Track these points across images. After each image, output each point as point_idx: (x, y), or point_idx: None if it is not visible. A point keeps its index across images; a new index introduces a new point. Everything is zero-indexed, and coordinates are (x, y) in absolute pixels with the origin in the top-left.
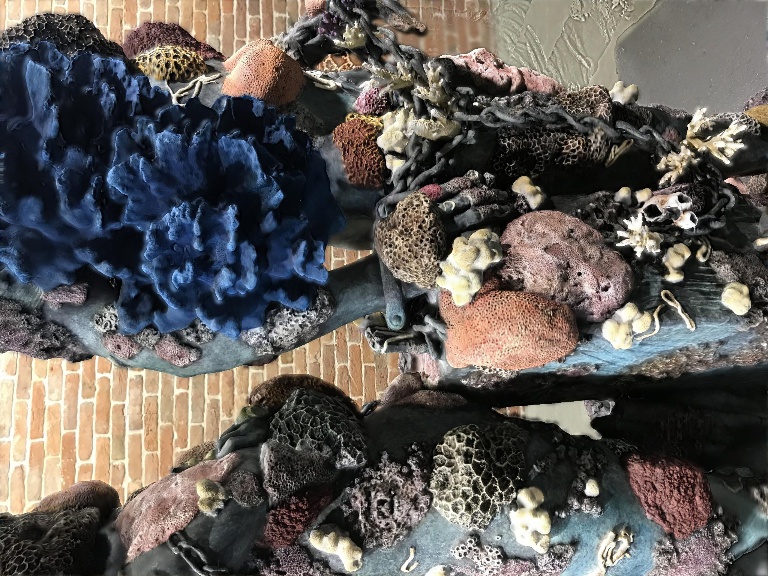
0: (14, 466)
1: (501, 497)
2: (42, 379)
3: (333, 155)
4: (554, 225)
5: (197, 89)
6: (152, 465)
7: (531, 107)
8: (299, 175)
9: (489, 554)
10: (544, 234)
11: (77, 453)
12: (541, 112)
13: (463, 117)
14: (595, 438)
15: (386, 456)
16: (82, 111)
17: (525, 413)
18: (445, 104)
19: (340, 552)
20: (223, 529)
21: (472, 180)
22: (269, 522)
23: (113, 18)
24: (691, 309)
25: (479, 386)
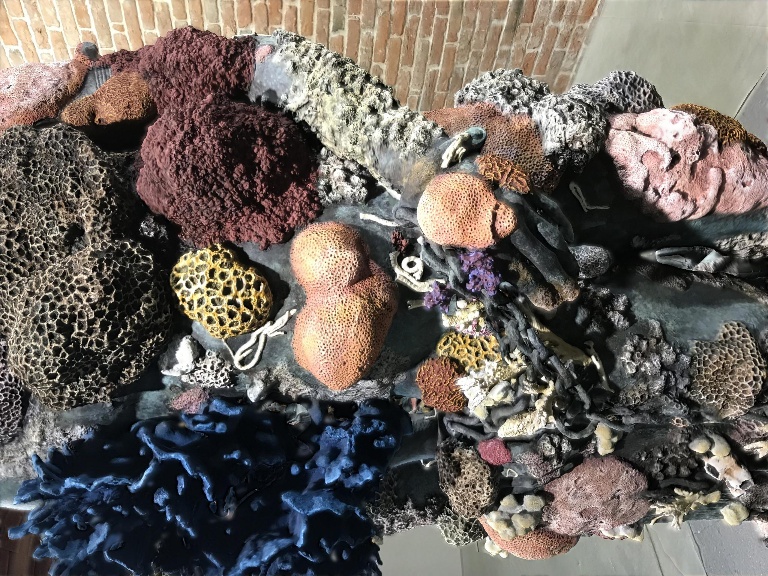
0: None
1: None
2: None
3: (413, 390)
4: (604, 490)
5: (261, 346)
6: None
7: (649, 419)
8: (368, 536)
9: None
10: (590, 496)
11: None
12: (657, 423)
13: (562, 433)
14: (682, 35)
15: (411, 504)
16: (160, 523)
17: None
18: (552, 403)
19: None
20: None
21: (546, 456)
22: None
23: None
24: (689, 515)
25: None
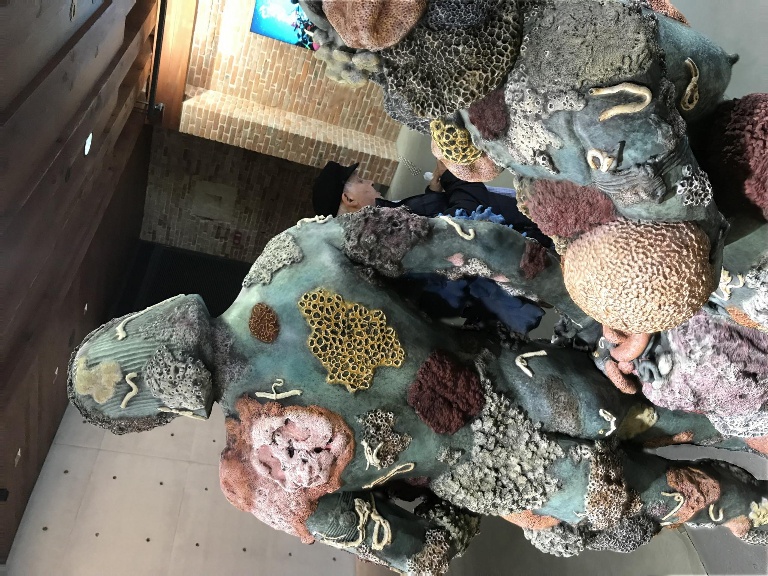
0: None
1: None
2: None
3: None
4: None
5: None
6: None
7: None
8: None
9: None
10: None
11: None
12: None
13: None
14: None
15: None
16: None
17: None
18: None
19: None
20: None
21: None
22: None
23: None
24: None
25: None
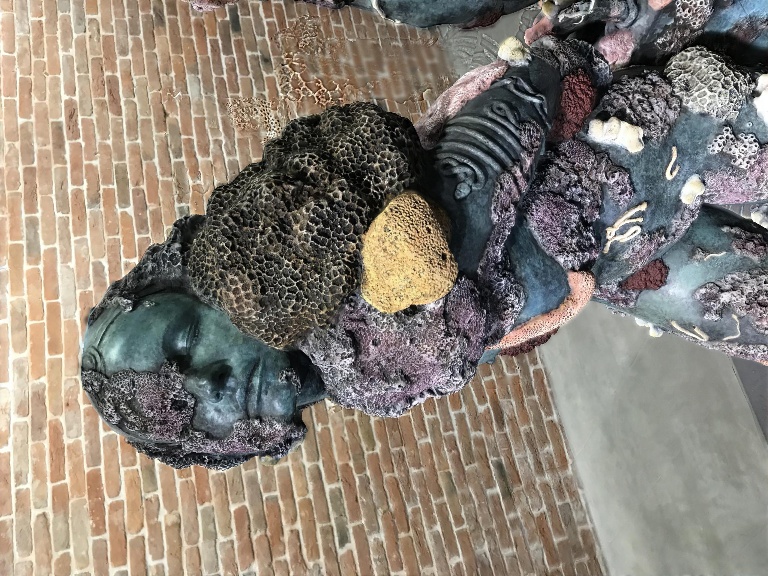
0: (35, 515)
1: (745, 83)
2: (58, 416)
3: None
4: None
5: None
6: (188, 492)
7: None
8: None
9: (745, 141)
10: None
11: (105, 490)
12: None
13: None
14: (636, 376)
15: (626, 76)
16: None
17: (551, 389)
18: None
19: (624, 132)
20: (539, 73)
21: None
22: (565, 89)
23: (93, 66)
24: None
25: (672, 47)
